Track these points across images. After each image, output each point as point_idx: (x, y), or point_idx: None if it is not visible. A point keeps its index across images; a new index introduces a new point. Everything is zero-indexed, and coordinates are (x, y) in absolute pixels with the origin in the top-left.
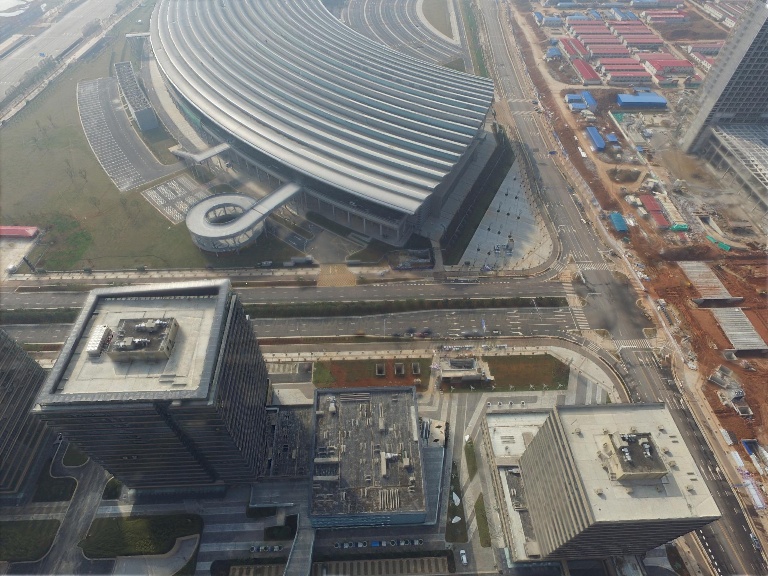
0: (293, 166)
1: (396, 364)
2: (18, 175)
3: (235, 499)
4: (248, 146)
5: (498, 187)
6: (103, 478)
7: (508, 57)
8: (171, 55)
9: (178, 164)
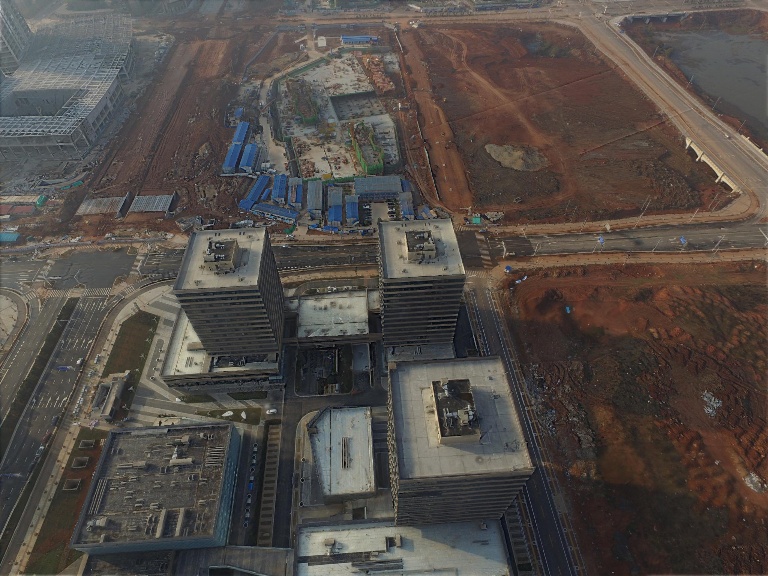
0: None
1: (72, 466)
2: None
3: None
4: None
5: None
6: None
7: None
8: None
9: None
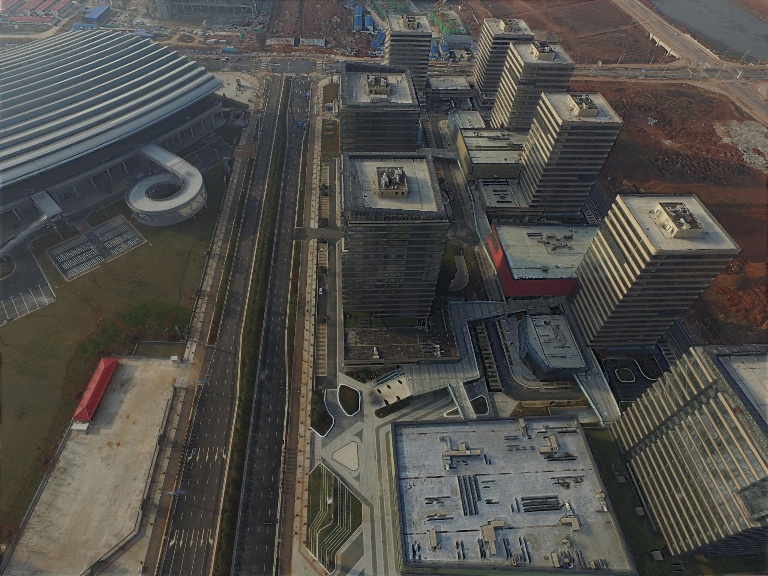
0: (132, 132)
1: (326, 129)
2: None
3: None
4: None
5: None
6: None
7: None
8: None
9: (17, 261)
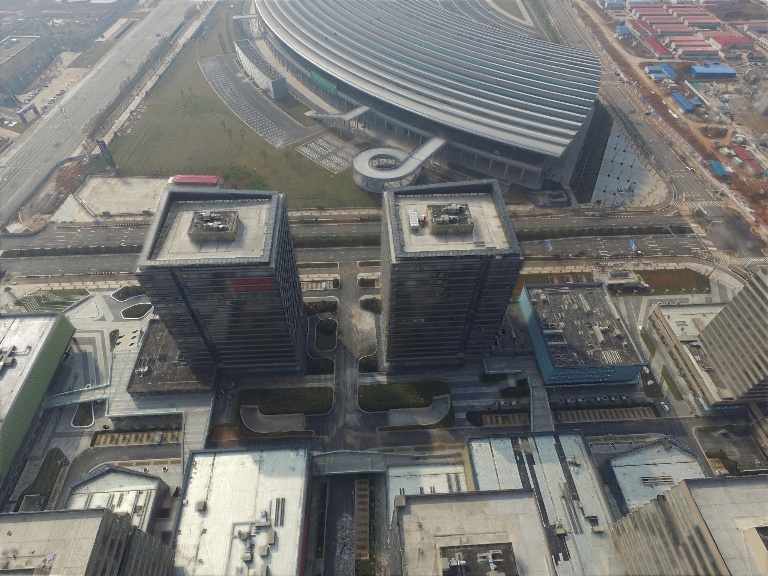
0: (441, 121)
1: (564, 276)
2: (180, 136)
3: (467, 371)
4: (387, 108)
5: (606, 143)
6: (354, 358)
7: (580, 36)
8: (293, 32)
9: (318, 126)
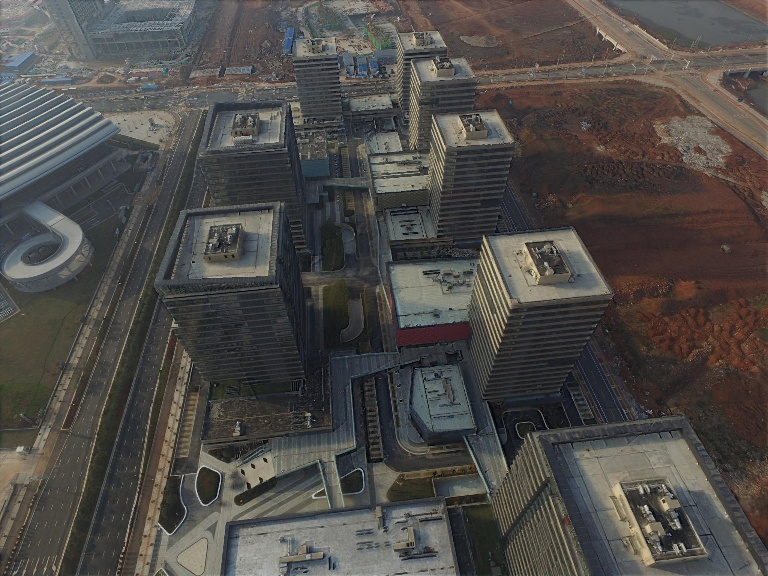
0: (11, 191)
1: None
2: None
3: None
4: None
5: None
6: None
7: None
8: None
9: None
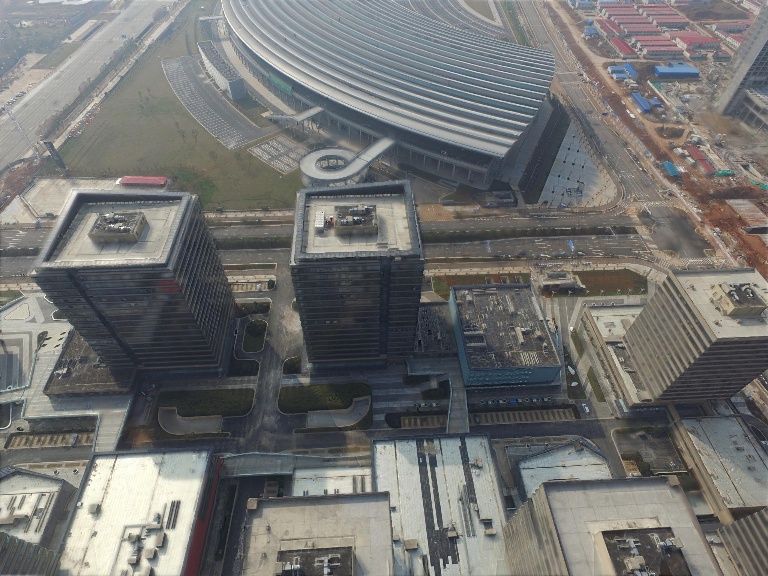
0: (389, 121)
1: (501, 277)
2: (133, 137)
3: (392, 373)
4: (340, 108)
5: (560, 143)
6: (279, 360)
7: (548, 36)
8: (254, 33)
9: (273, 127)
